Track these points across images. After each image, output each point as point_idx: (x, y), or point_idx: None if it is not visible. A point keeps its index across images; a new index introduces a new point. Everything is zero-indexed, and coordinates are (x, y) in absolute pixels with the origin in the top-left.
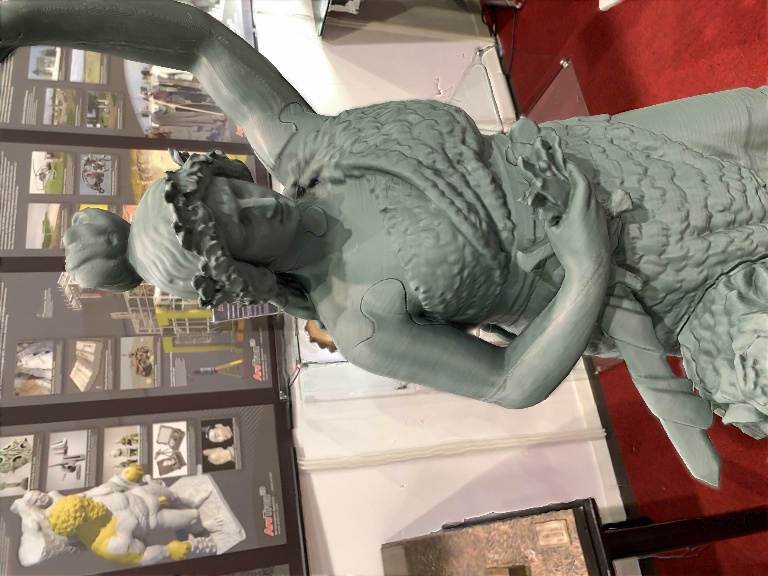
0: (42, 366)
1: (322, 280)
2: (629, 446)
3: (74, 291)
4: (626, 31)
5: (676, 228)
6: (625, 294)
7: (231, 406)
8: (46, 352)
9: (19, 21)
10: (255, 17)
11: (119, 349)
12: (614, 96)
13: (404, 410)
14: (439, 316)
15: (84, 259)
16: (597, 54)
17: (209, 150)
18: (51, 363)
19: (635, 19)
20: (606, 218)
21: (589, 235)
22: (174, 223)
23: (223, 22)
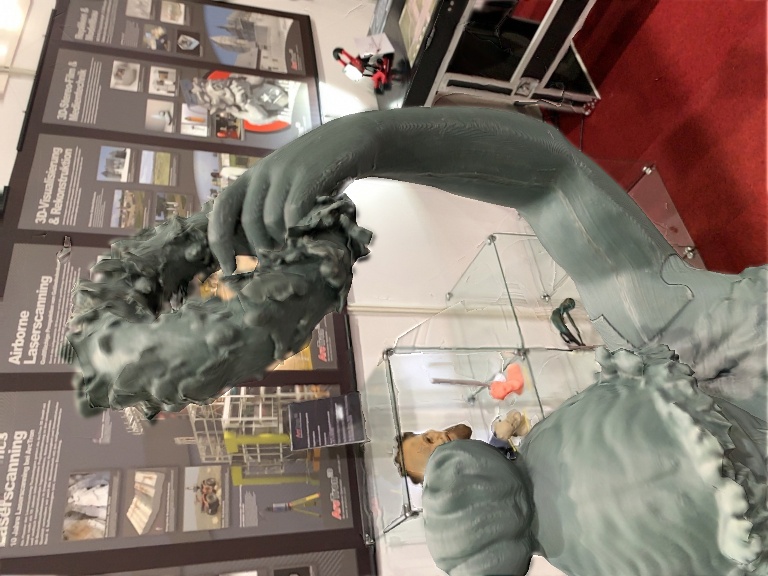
0: (96, 503)
1: None
2: None
3: (135, 412)
4: (725, 139)
5: None
6: None
7: (307, 551)
8: (101, 485)
9: (376, 145)
10: (324, 121)
11: (183, 481)
12: (713, 204)
13: None
14: None
15: (484, 544)
16: (688, 161)
17: None
18: (106, 499)
19: (736, 127)
20: None
21: None
22: (749, 522)
23: (292, 125)
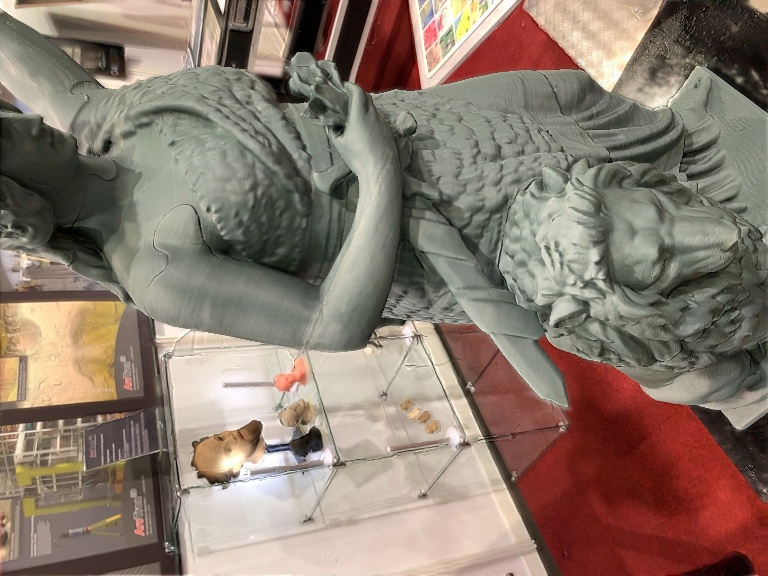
0: None
1: (115, 230)
2: (560, 551)
3: None
4: None
5: (467, 153)
6: (427, 207)
7: (107, 571)
8: None
9: None
10: None
11: None
12: None
13: (314, 549)
14: (243, 250)
15: None
16: None
17: (86, 299)
18: None
19: None
20: (393, 135)
21: (371, 135)
22: None
23: None
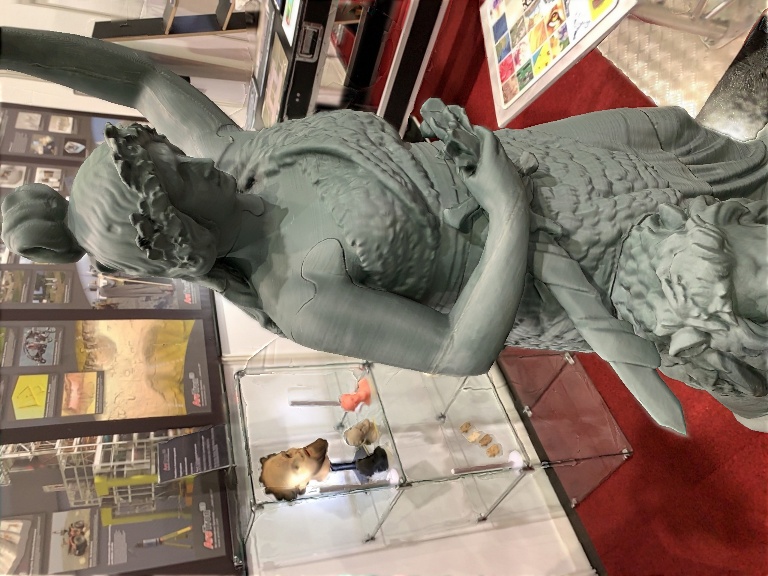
0: None
1: (262, 260)
2: None
3: (3, 465)
4: None
5: (583, 189)
6: (549, 241)
7: None
8: None
9: None
10: None
11: (50, 526)
12: None
13: (375, 569)
14: (379, 280)
15: (21, 218)
16: None
17: (157, 317)
18: None
19: None
20: None
21: (503, 175)
22: (114, 151)
23: None
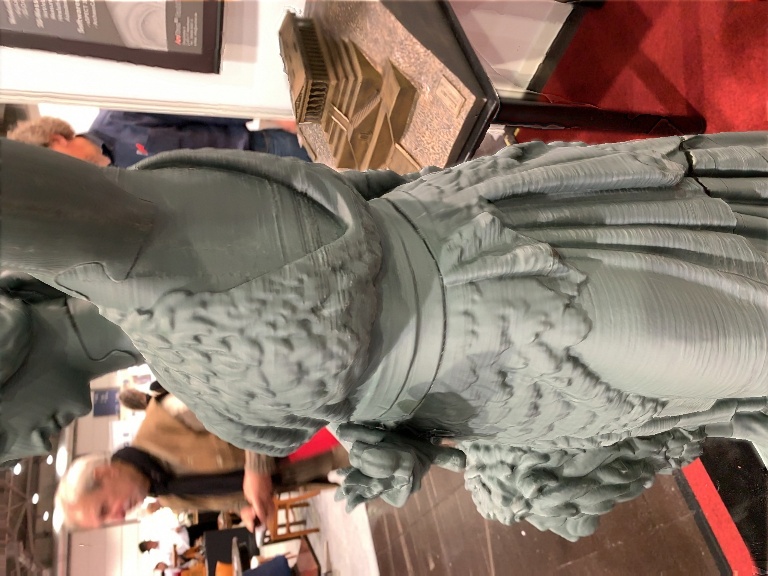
0: None
1: None
2: None
3: None
4: None
5: None
6: None
7: None
8: None
9: None
10: None
11: None
12: None
13: None
14: None
15: None
16: None
17: None
18: None
19: None
20: None
21: None
22: None
23: None
